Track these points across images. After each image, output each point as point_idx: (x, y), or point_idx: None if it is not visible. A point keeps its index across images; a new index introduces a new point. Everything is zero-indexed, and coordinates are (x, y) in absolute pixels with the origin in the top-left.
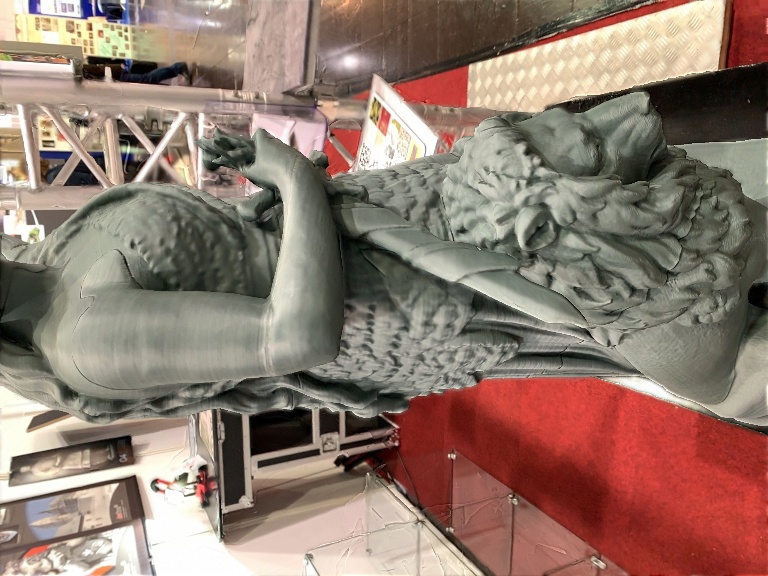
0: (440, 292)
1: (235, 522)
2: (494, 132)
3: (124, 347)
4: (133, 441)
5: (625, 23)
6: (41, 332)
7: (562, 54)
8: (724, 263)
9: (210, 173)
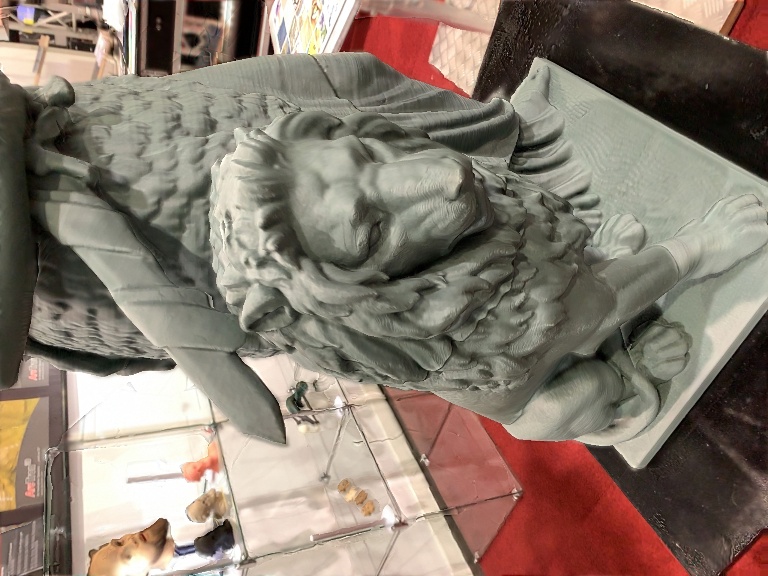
0: None
1: None
2: (243, 173)
3: None
4: None
5: None
6: None
7: None
8: (505, 366)
9: None
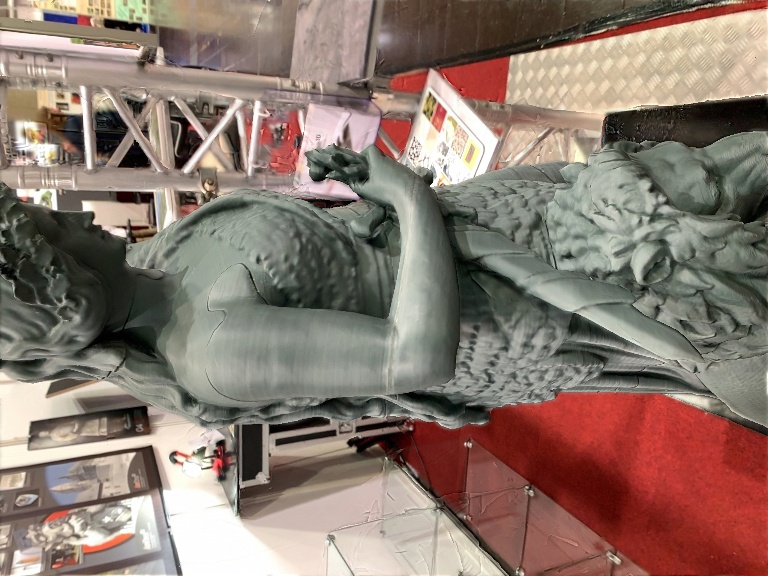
0: (541, 315)
1: (250, 497)
2: (616, 165)
3: (257, 363)
4: (149, 411)
5: (681, 25)
6: (166, 340)
7: (611, 52)
8: None
9: (261, 160)
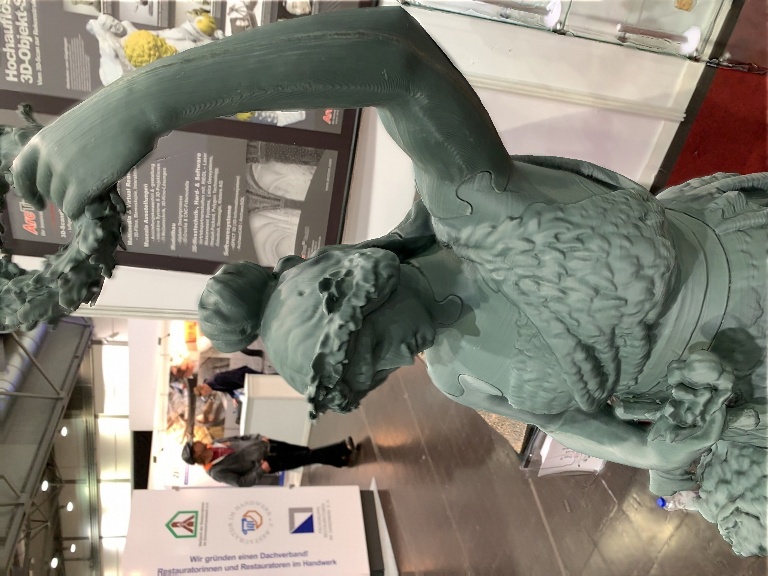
0: None
1: None
2: (765, 548)
3: None
4: None
5: None
6: None
7: None
8: None
9: None
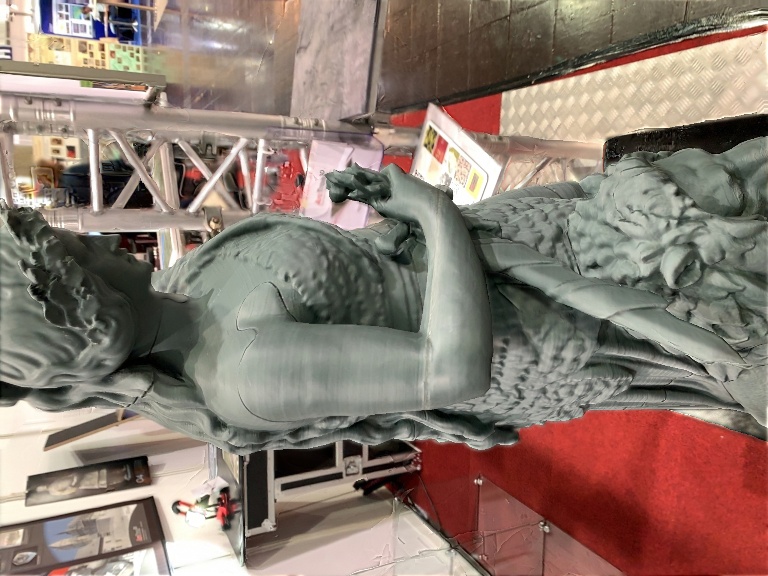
0: (569, 326)
1: (256, 546)
2: (638, 172)
3: (291, 380)
4: (149, 461)
5: (668, 56)
6: (195, 363)
7: (601, 84)
8: None
9: (266, 198)
